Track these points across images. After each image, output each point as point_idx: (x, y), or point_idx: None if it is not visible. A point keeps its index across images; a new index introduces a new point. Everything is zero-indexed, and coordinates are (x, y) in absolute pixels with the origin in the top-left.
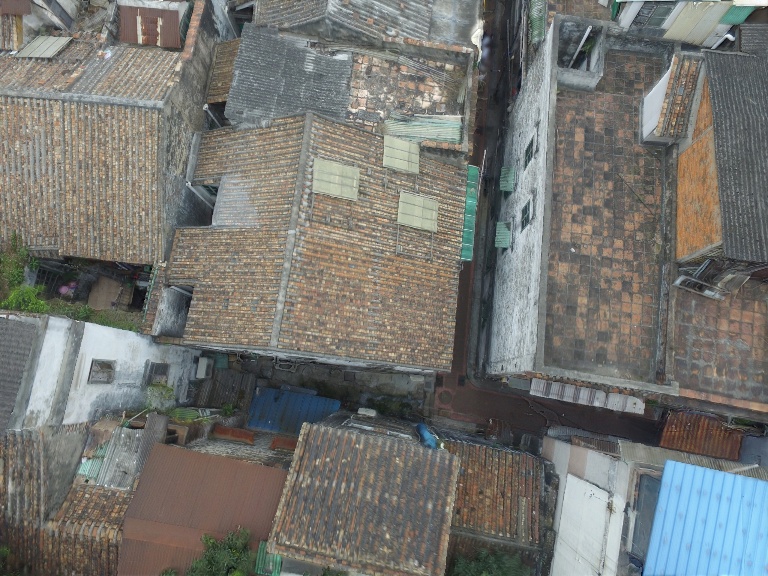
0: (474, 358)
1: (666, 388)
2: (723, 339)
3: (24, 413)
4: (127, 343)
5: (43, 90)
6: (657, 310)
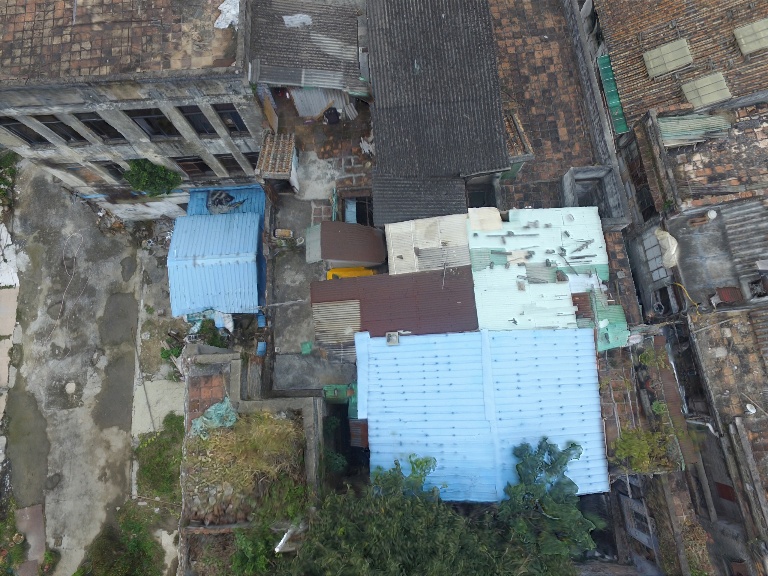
0: None
1: None
2: None
3: None
4: None
5: None
6: None
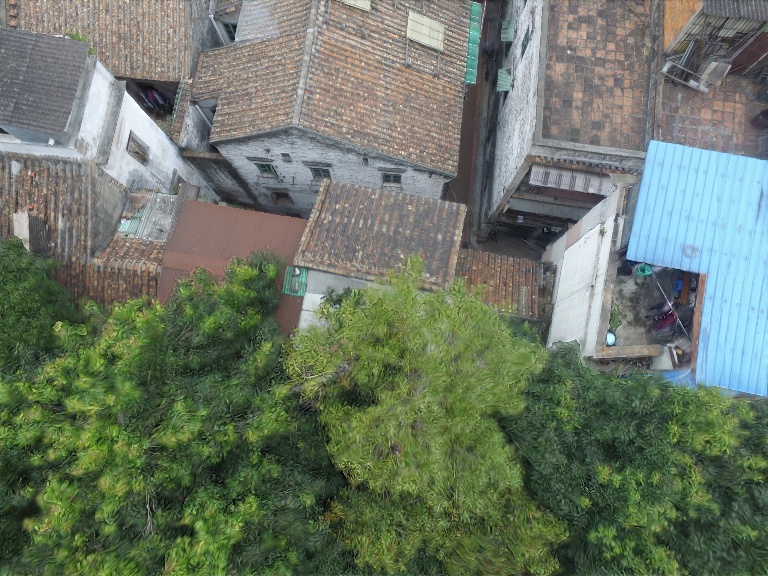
0: (477, 225)
1: None
2: (707, 126)
3: (77, 134)
4: (158, 139)
5: None
6: (646, 102)
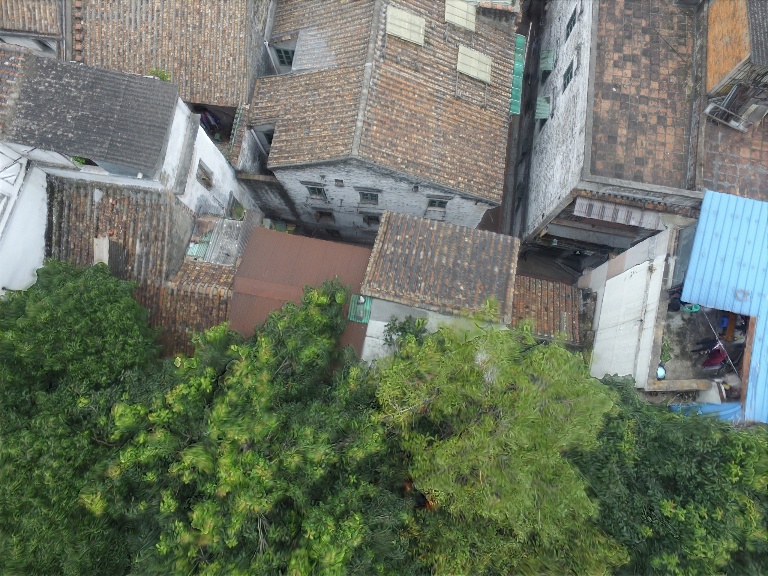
0: None
1: (697, 193)
2: (745, 165)
3: (161, 168)
4: (220, 164)
5: None
6: (688, 140)
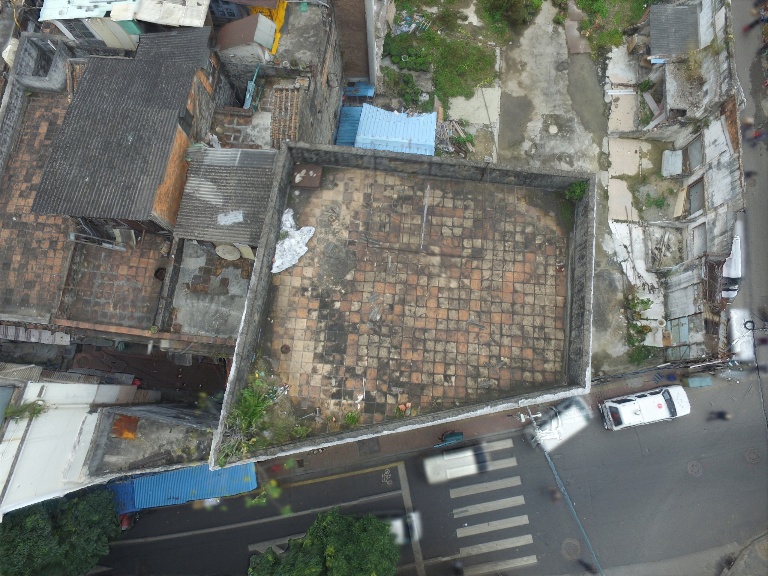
0: None
1: (38, 319)
2: (122, 281)
3: None
4: None
5: None
6: None
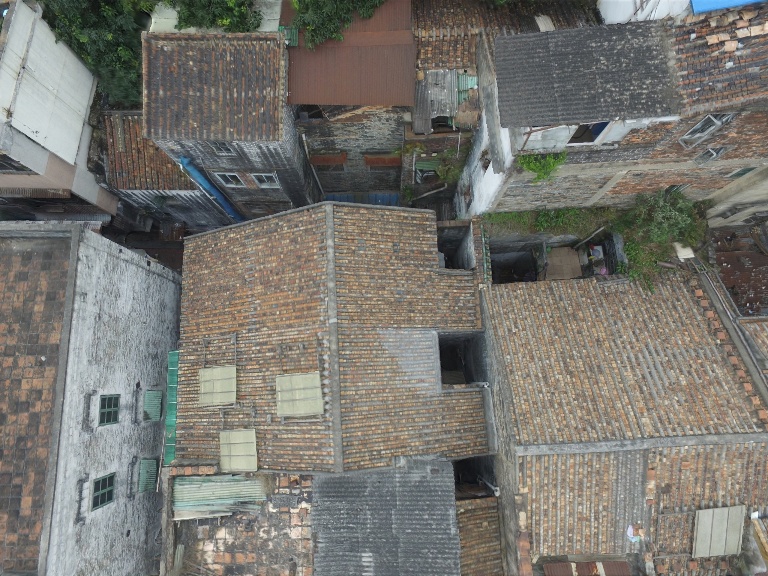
0: None
1: None
2: None
3: None
4: (484, 197)
5: (676, 450)
6: None
